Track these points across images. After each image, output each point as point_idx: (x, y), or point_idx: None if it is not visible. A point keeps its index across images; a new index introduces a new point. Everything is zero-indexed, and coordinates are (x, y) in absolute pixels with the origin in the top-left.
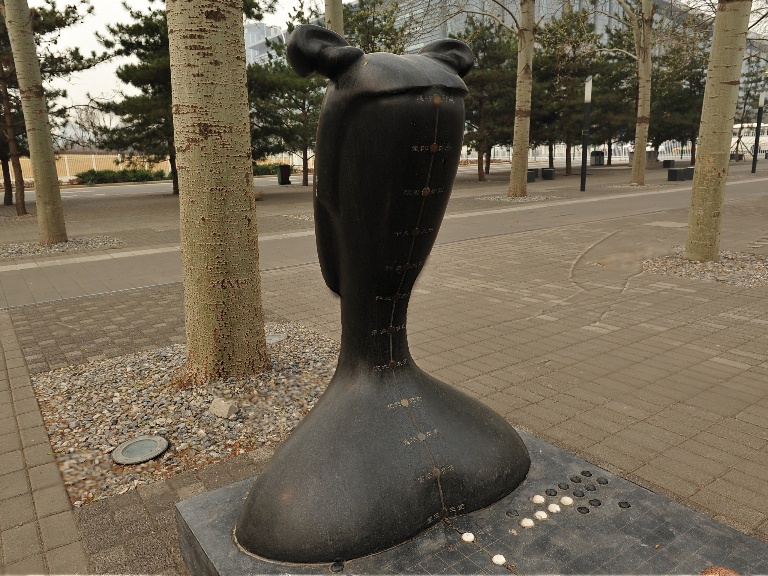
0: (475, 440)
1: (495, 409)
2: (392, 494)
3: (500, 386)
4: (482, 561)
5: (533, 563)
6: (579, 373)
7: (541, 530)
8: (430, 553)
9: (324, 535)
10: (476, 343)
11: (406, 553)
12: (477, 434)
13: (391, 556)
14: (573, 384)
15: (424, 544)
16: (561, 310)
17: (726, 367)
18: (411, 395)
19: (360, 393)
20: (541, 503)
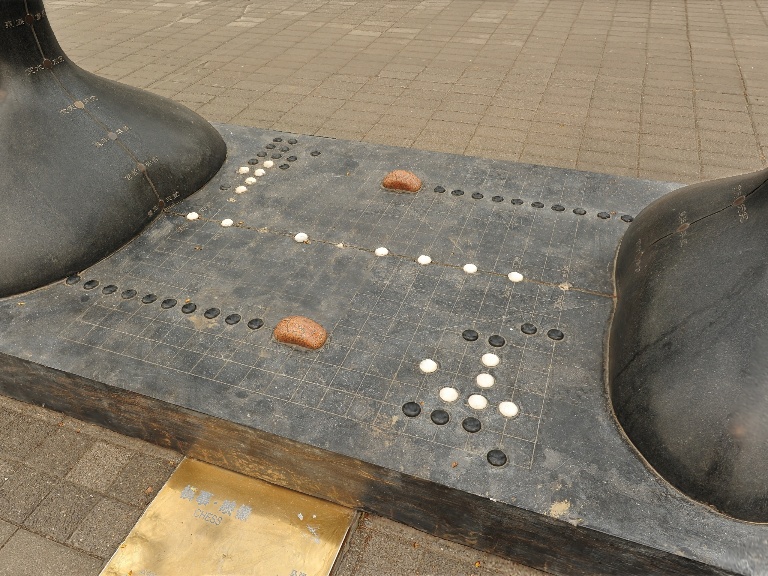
0: (169, 129)
1: None
2: (103, 198)
3: (166, 96)
4: (213, 229)
5: (257, 216)
6: (240, 67)
7: (255, 191)
8: (162, 239)
9: (45, 256)
10: (122, 59)
11: (139, 246)
12: (169, 124)
13: (125, 253)
14: (238, 78)
15: (153, 234)
16: (201, 10)
17: (363, 37)
18: (83, 96)
19: (20, 104)
20: (247, 172)
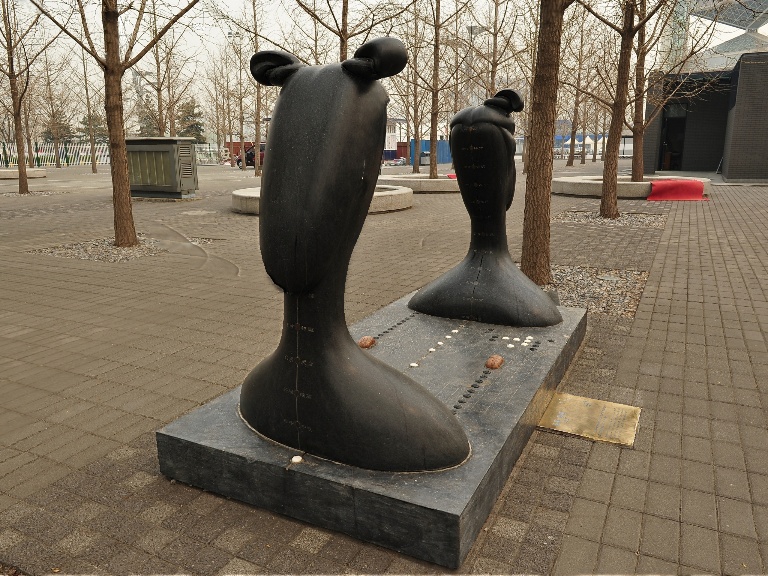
0: None
1: (55, 477)
2: None
3: None
4: None
5: None
6: None
7: None
8: None
9: None
10: None
11: None
12: None
13: None
14: None
15: None
16: None
17: None
18: None
19: None
20: None
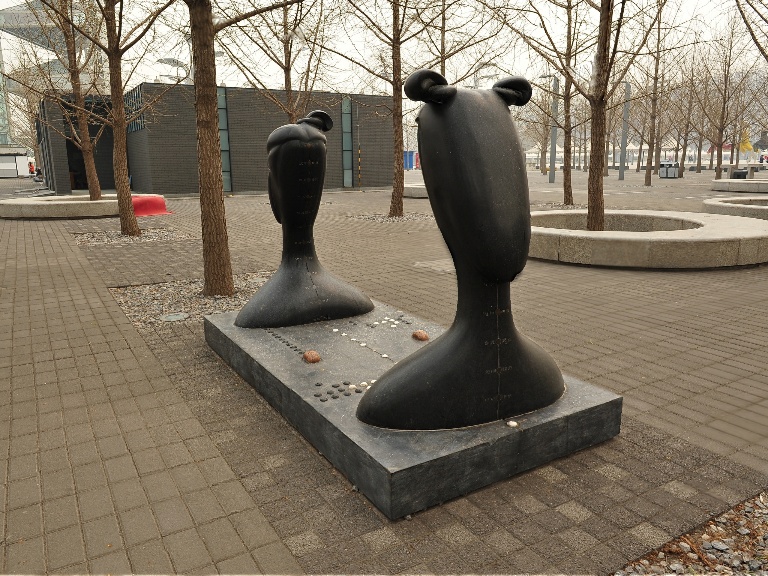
0: None
1: None
2: None
3: None
4: None
5: None
6: None
7: None
8: None
9: None
10: None
11: None
12: None
13: None
14: None
15: None
16: None
17: None
18: None
19: None
20: None
